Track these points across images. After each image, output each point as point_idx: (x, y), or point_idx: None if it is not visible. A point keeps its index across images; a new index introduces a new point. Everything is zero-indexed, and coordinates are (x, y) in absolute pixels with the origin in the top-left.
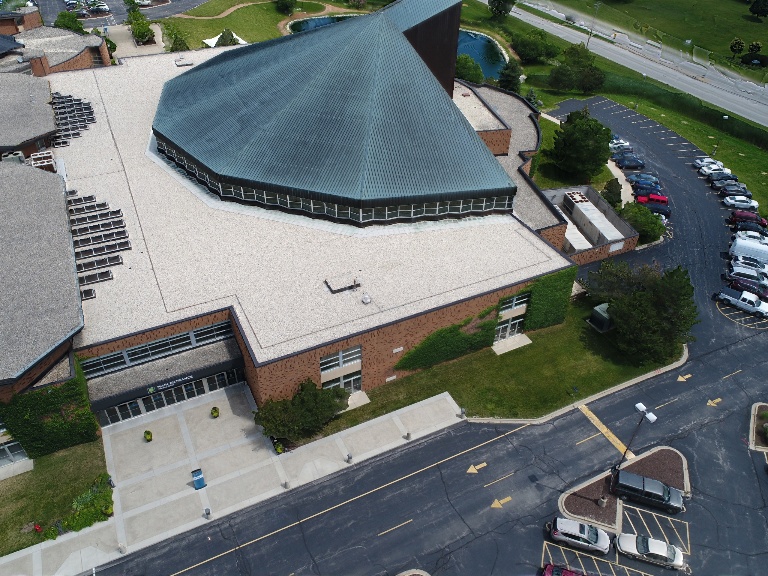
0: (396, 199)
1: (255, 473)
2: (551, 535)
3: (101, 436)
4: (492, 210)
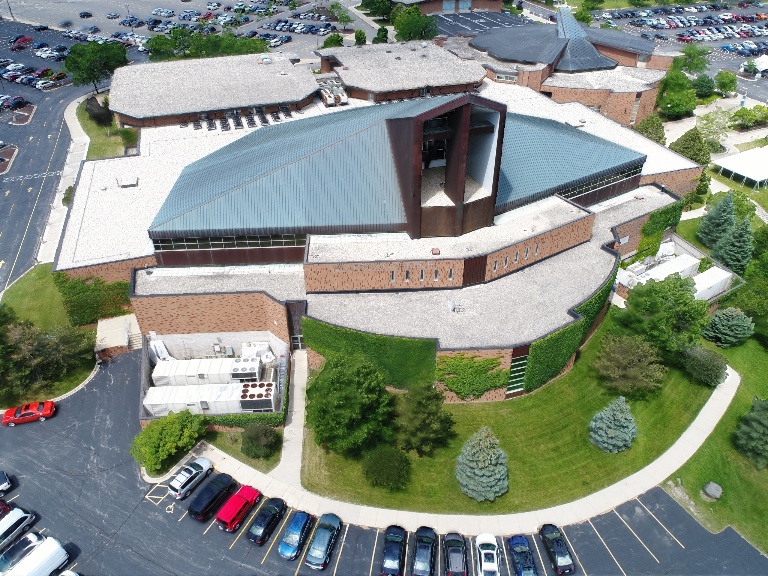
0: None
1: None
2: None
3: None
4: None
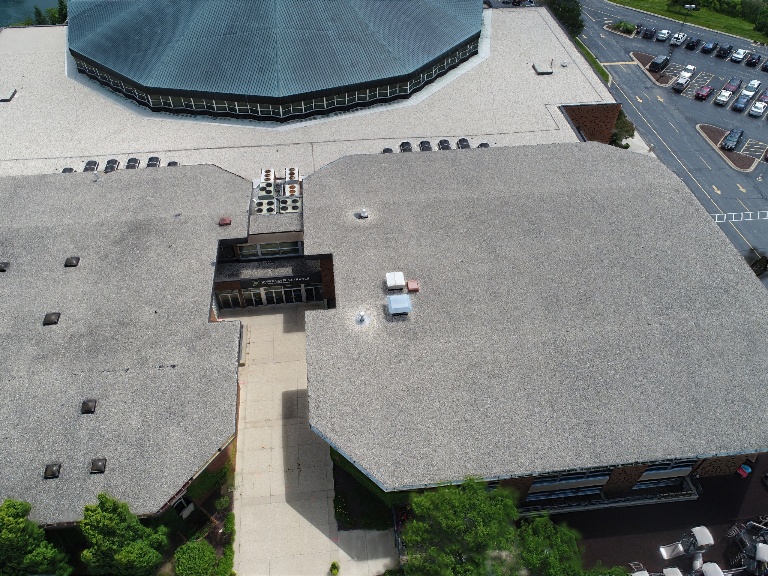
0: None
1: None
2: (681, 90)
3: None
4: None
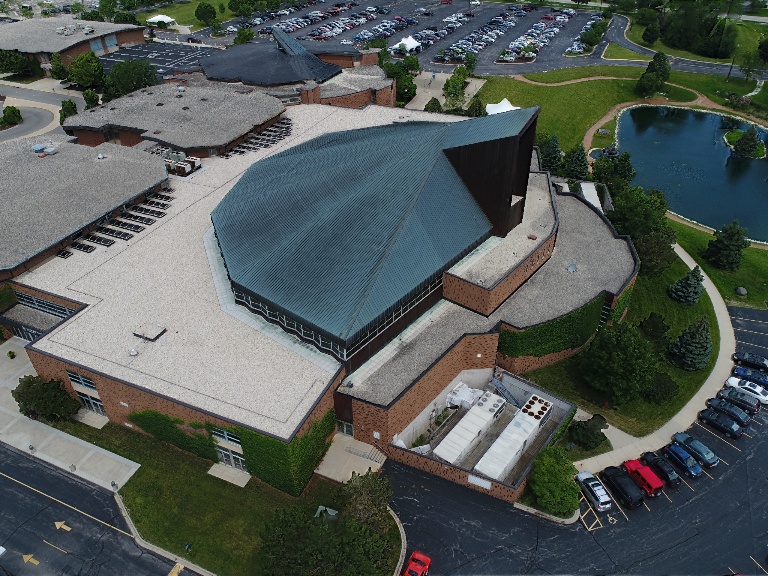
0: (254, 293)
1: (3, 415)
2: None
3: (7, 340)
4: (331, 351)
